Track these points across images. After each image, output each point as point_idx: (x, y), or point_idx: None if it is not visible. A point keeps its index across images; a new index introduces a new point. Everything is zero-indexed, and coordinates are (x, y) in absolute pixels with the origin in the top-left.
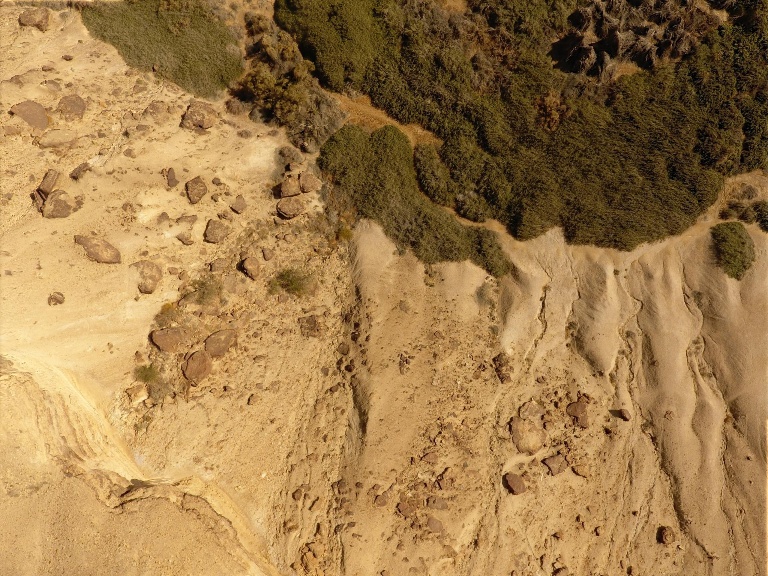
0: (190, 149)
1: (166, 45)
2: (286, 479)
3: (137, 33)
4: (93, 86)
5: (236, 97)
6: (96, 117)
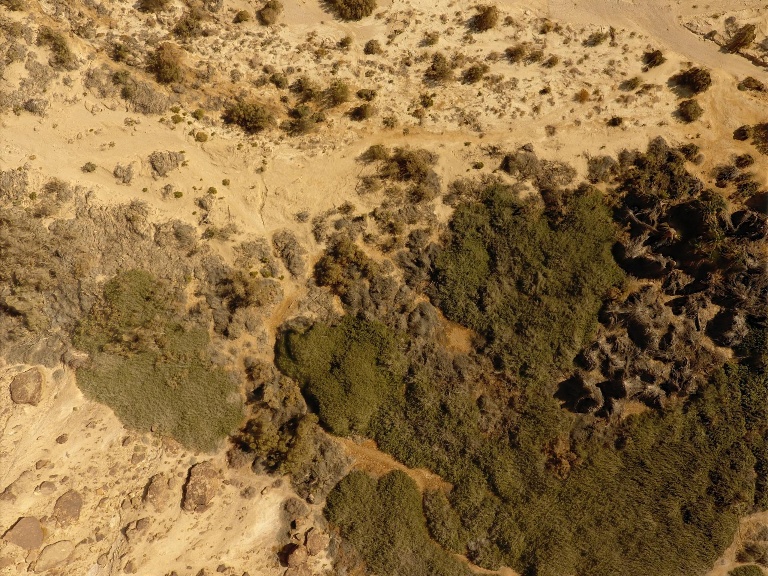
0: (193, 535)
1: (164, 401)
2: None
3: (134, 390)
4: (89, 471)
5: (238, 444)
6: (93, 512)
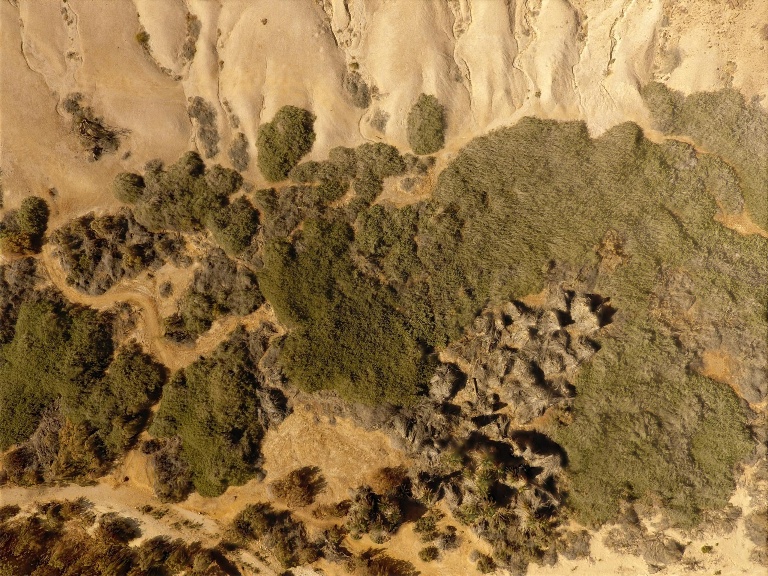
0: None
1: None
2: None
3: None
4: None
5: None
6: None
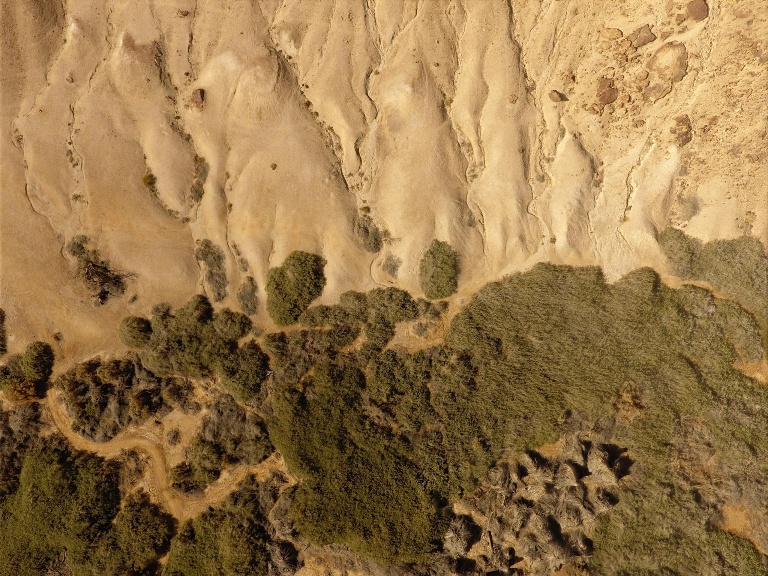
0: None
1: None
2: None
3: None
4: None
5: None
6: None
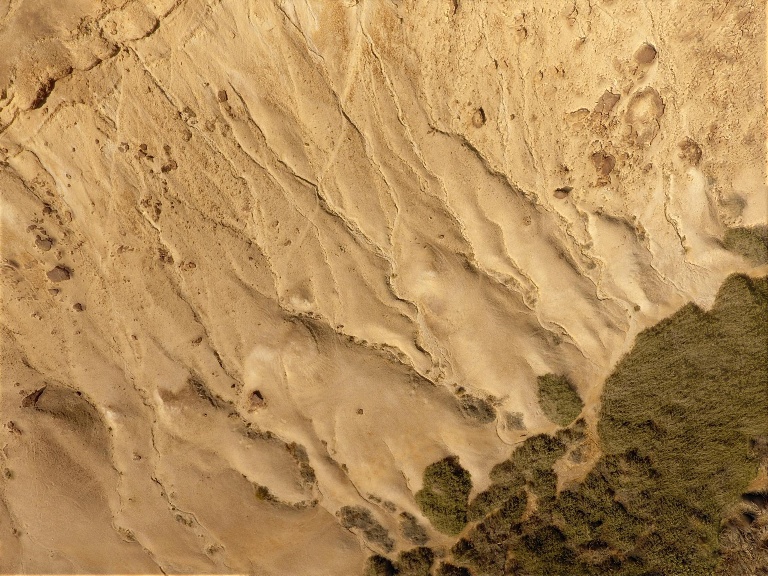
0: None
1: None
2: None
3: None
4: None
5: None
6: None
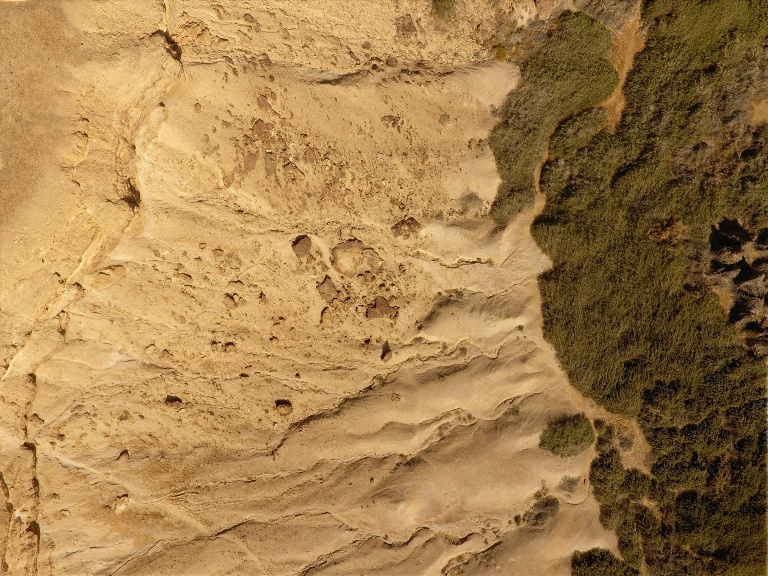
0: None
1: None
2: (260, 8)
3: None
4: None
5: None
6: None
